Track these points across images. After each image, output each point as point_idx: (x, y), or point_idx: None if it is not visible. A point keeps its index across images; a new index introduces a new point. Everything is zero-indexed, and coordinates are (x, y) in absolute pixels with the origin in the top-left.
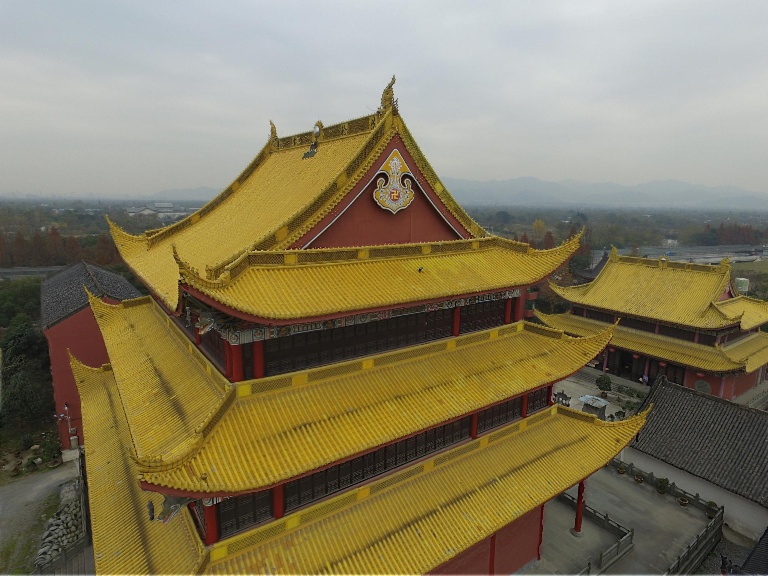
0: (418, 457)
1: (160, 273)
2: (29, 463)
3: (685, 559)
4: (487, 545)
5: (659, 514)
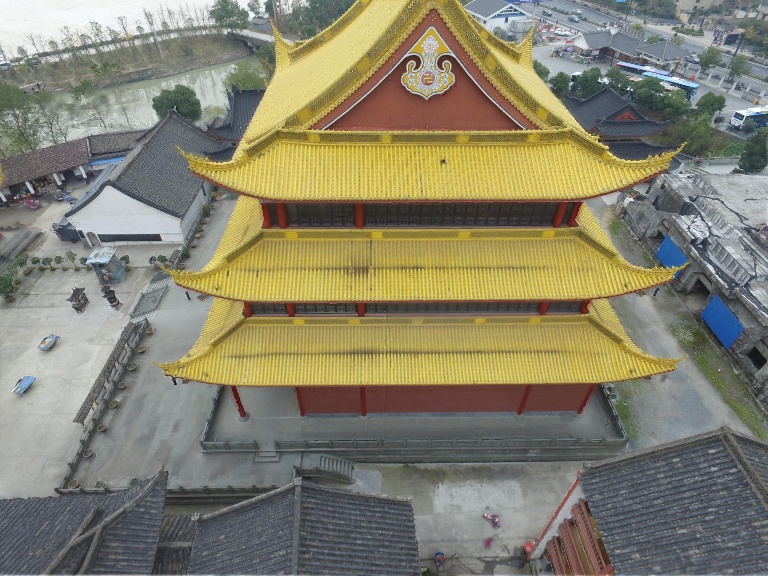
0: None
1: None
2: None
3: None
4: None
5: None
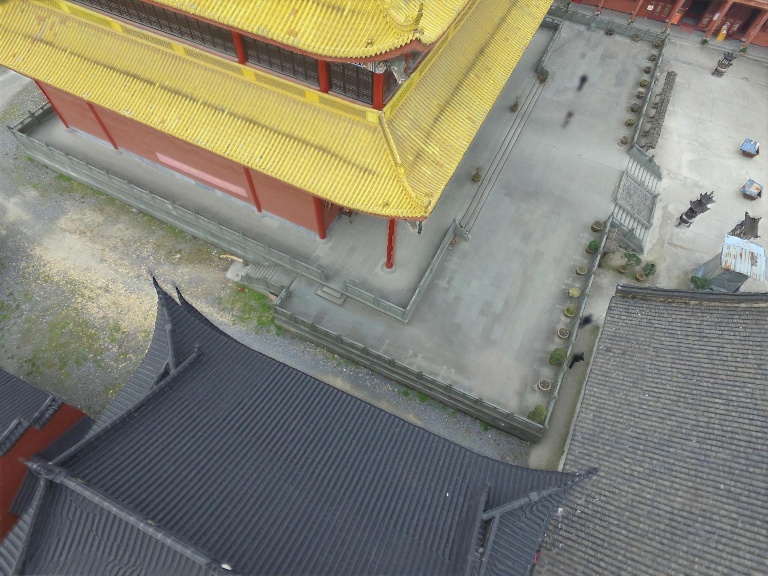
0: (174, 34)
1: None
2: None
3: (413, 373)
4: (240, 168)
5: (496, 356)
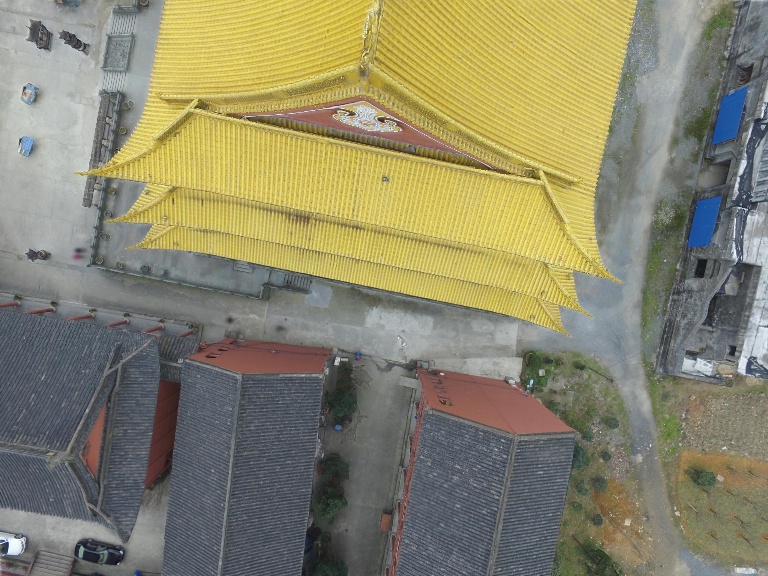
0: None
1: (623, 1)
2: (548, 374)
3: None
4: None
5: None
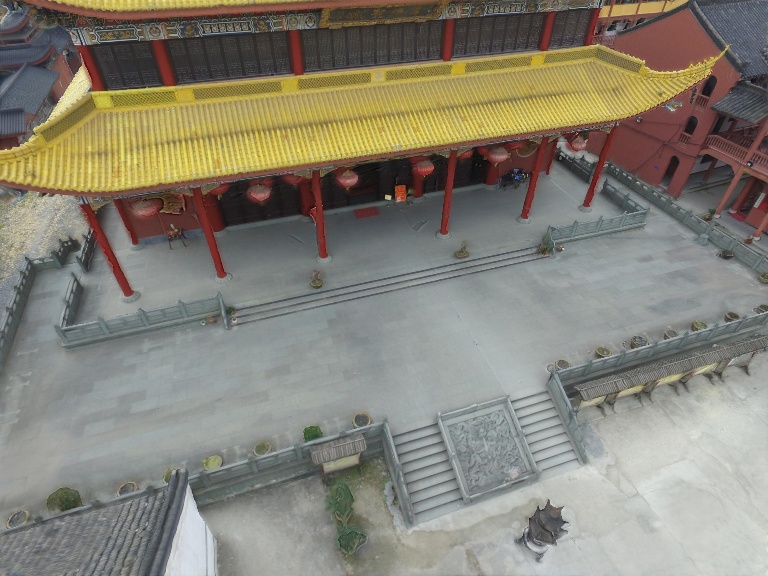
0: None
1: None
2: None
3: None
4: None
5: (58, 446)
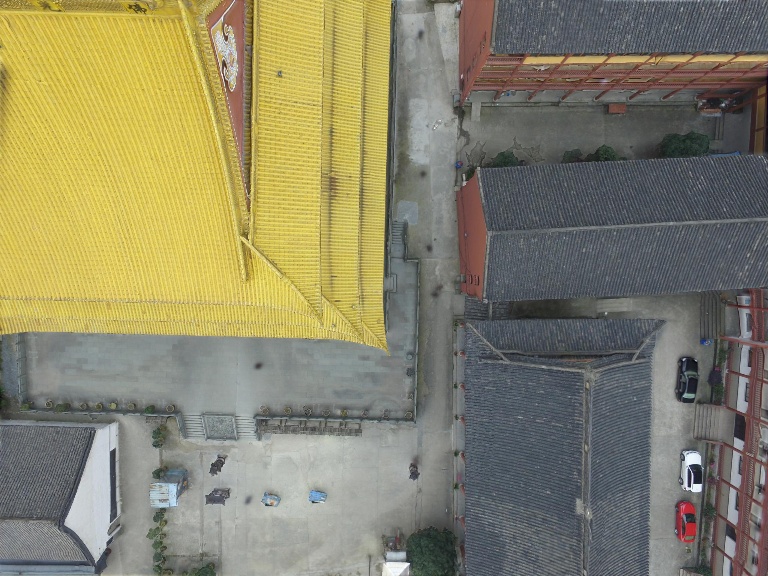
0: None
1: None
2: None
3: (22, 338)
4: None
5: (56, 376)
